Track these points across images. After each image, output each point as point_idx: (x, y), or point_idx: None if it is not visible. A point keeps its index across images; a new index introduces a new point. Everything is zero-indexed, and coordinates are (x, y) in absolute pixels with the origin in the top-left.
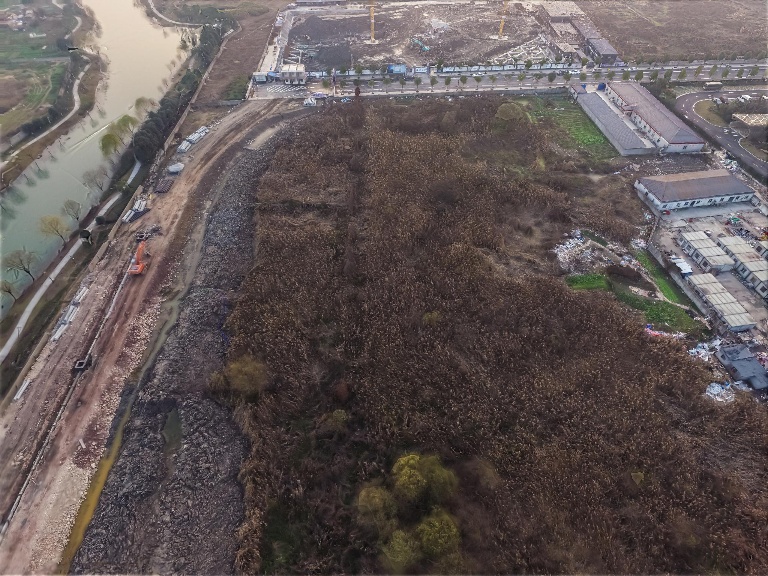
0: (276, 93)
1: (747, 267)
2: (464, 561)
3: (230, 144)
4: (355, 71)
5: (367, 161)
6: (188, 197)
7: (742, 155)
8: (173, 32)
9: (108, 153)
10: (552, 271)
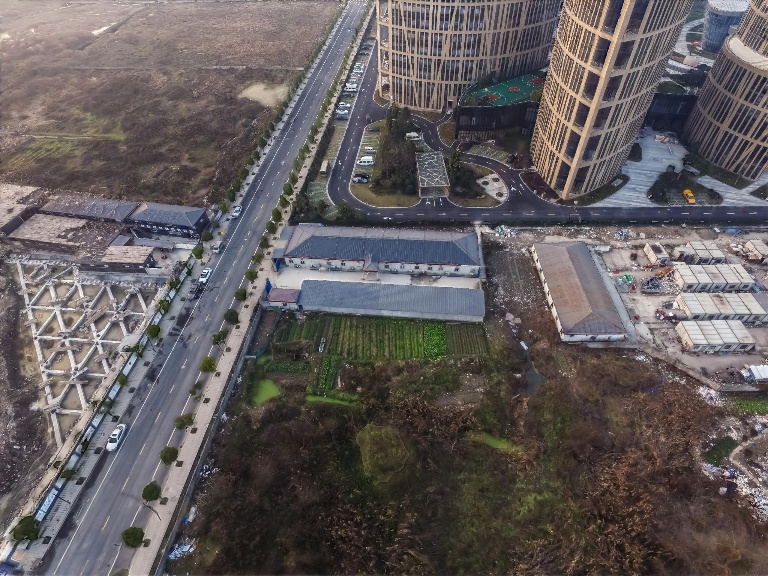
0: None
1: (745, 314)
2: None
3: None
4: None
5: None
6: None
7: (485, 215)
8: None
9: None
10: None
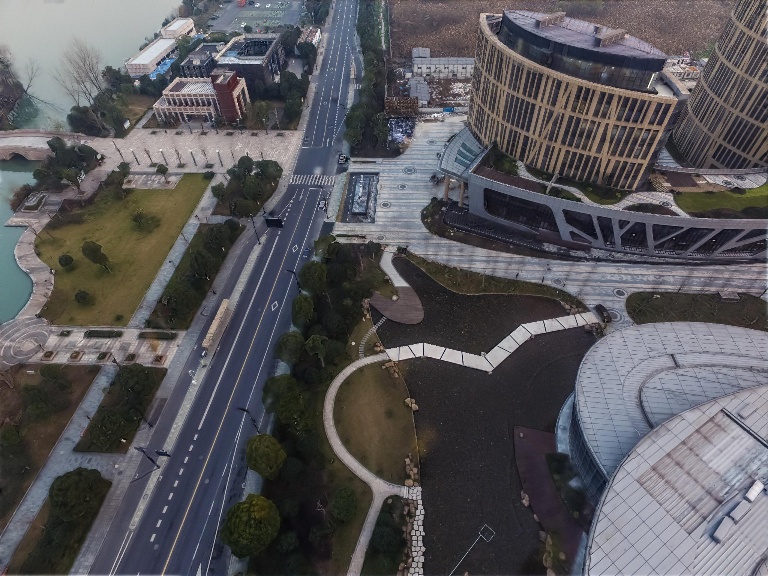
0: None
1: None
2: (576, 1)
3: None
4: None
5: None
6: None
7: None
8: None
9: None
10: None
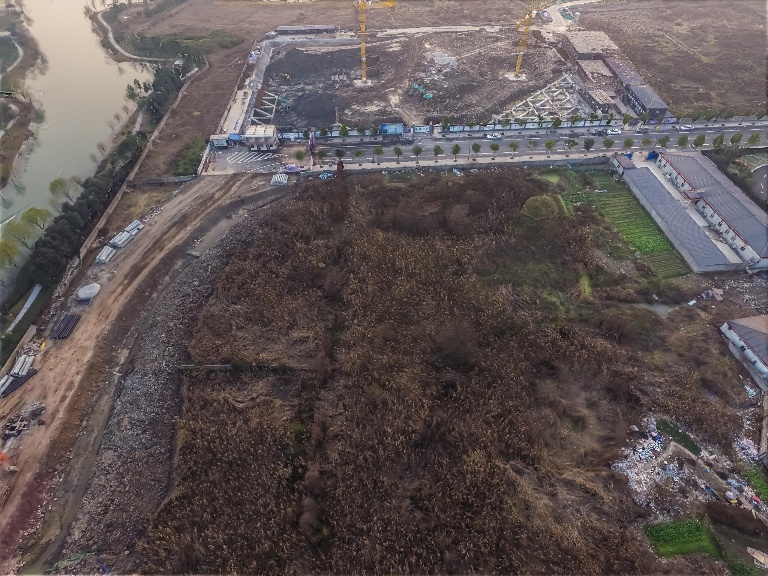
0: (238, 165)
1: None
2: None
3: (168, 249)
4: (339, 133)
5: (347, 289)
6: (94, 348)
7: None
8: (130, 68)
9: (0, 267)
10: (623, 511)
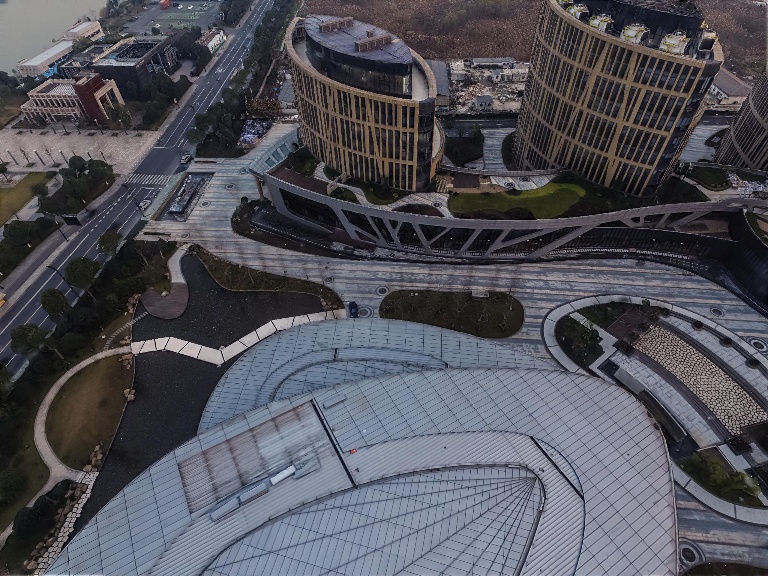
0: None
1: None
2: (481, 2)
3: None
4: None
5: None
6: None
7: None
8: None
9: None
10: None
